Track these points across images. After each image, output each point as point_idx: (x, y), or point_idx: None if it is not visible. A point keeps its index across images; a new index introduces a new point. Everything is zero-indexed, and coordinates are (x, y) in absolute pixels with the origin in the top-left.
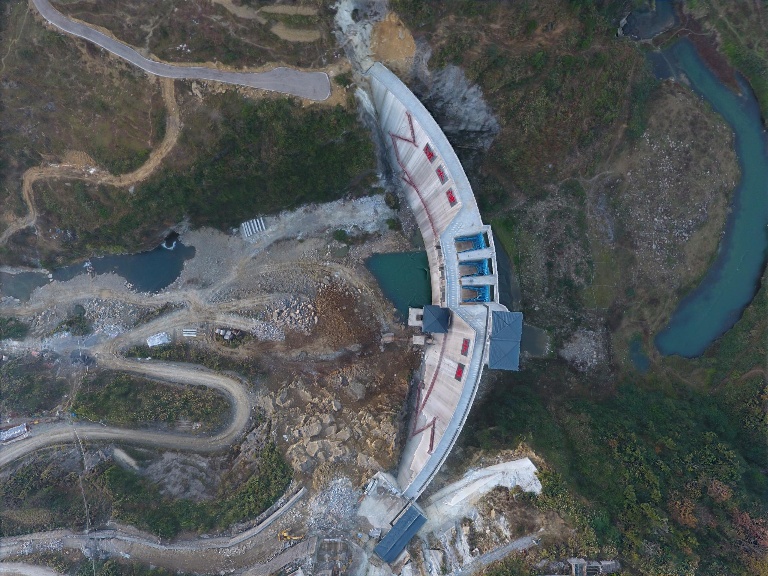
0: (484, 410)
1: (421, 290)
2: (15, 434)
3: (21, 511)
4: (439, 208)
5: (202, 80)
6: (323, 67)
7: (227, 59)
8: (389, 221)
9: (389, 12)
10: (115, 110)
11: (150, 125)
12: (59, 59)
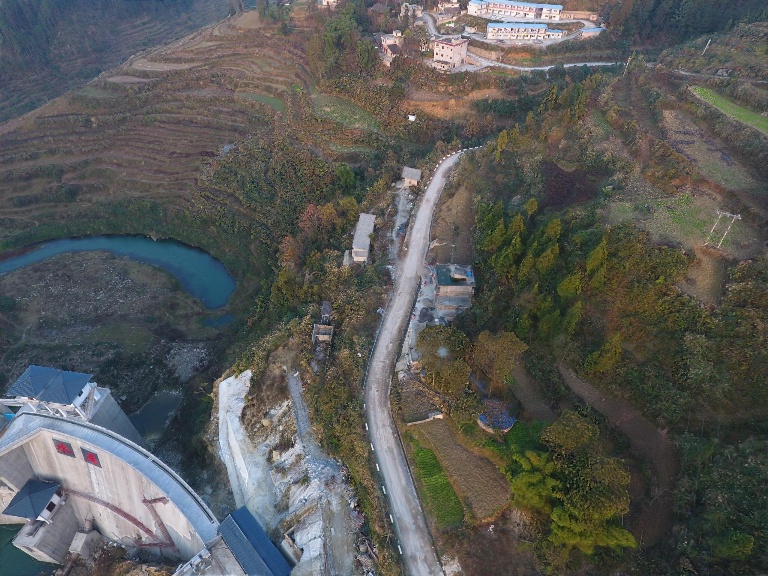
0: None
1: None
2: None
3: None
4: None
5: None
6: None
7: None
8: None
9: None
10: None
11: None
12: None
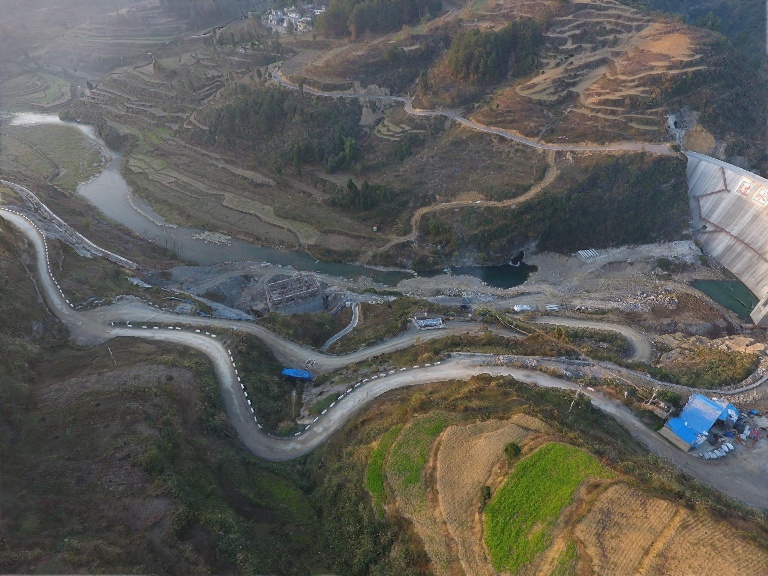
0: None
1: None
2: (432, 323)
3: (476, 347)
4: (759, 228)
5: (575, 150)
6: (661, 142)
7: (596, 139)
8: (702, 256)
9: (697, 124)
10: (507, 168)
11: (534, 173)
12: (476, 145)
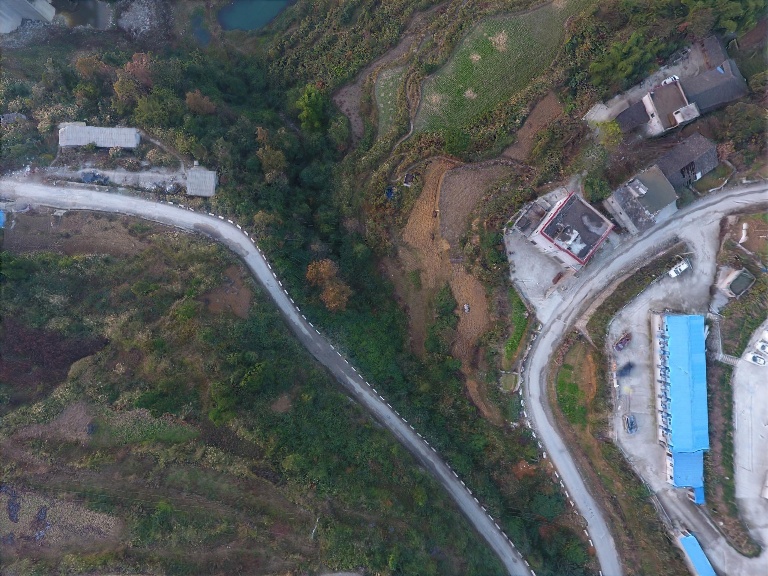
0: None
1: None
2: None
3: None
4: None
5: None
6: None
7: None
8: None
9: None
10: None
11: None
12: None
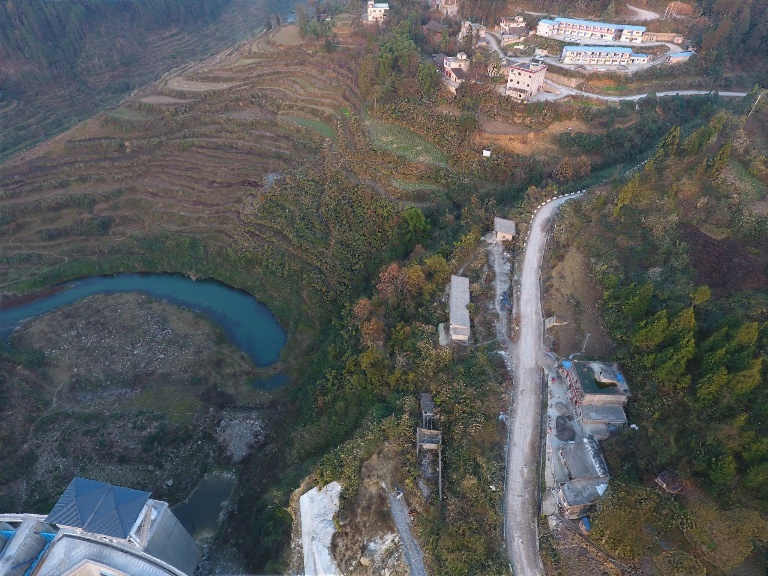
0: (256, 570)
1: None
2: None
3: None
4: None
5: None
6: None
7: None
8: None
9: None
10: None
11: None
12: None
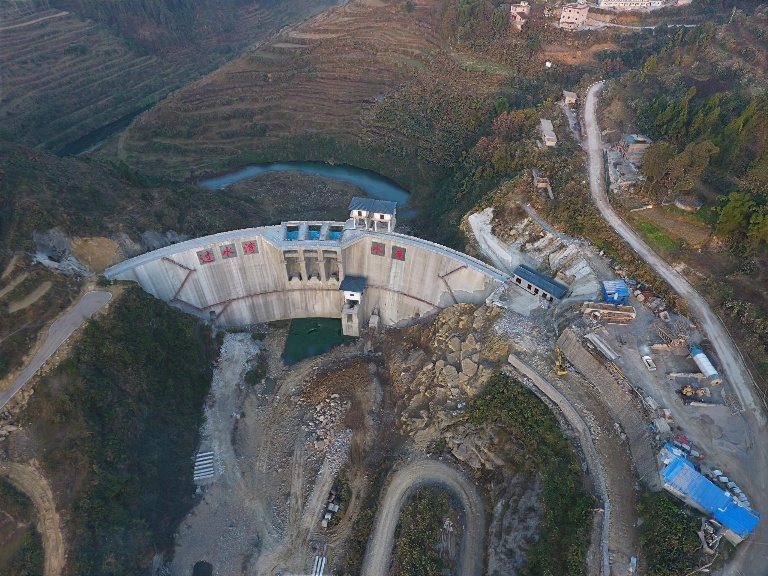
0: None
1: (329, 334)
2: None
3: None
4: (256, 274)
5: None
6: (80, 292)
7: (1, 370)
8: (253, 335)
9: (71, 240)
10: None
11: None
12: None
